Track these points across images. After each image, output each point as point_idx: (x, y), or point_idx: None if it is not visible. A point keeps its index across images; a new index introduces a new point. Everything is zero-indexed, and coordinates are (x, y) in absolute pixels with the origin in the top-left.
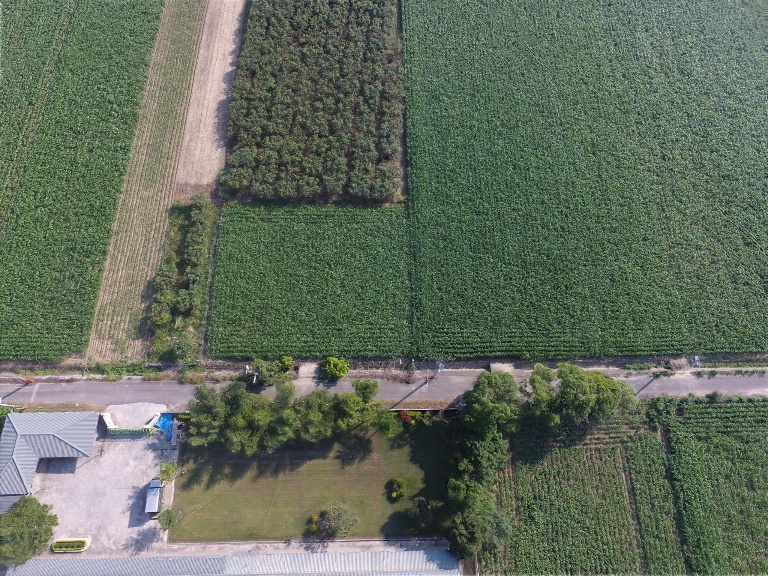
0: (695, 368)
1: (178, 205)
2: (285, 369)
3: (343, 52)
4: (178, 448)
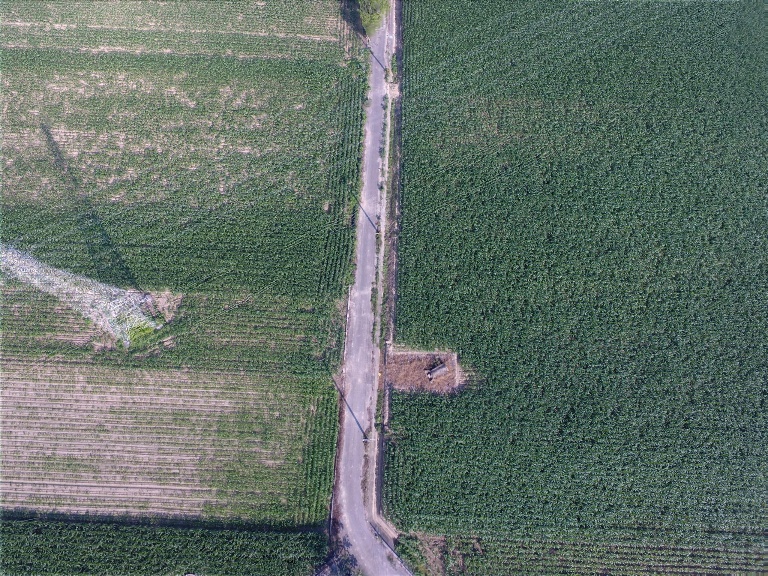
0: None
1: None
2: None
3: None
4: None
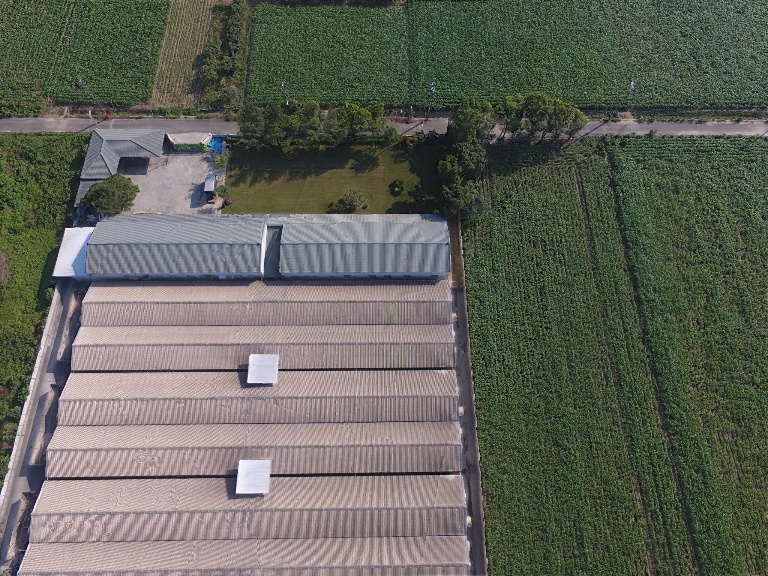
0: None
1: (219, 5)
2: None
3: None
4: None
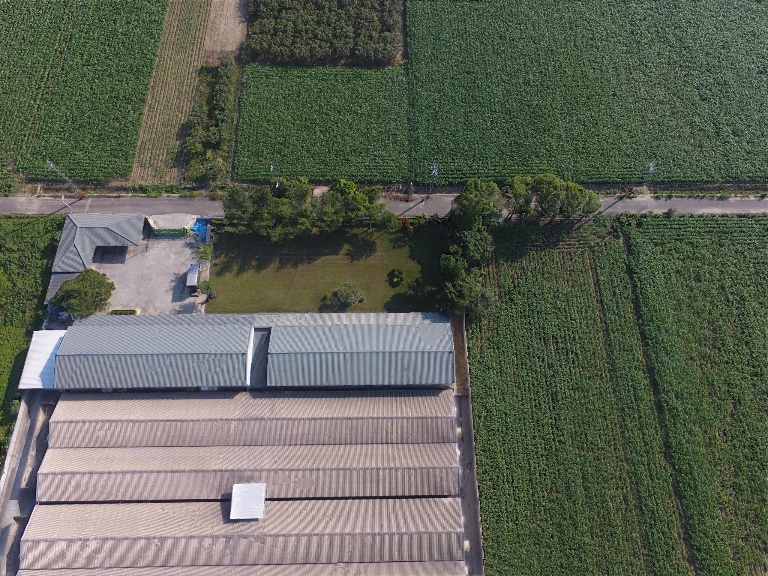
0: (654, 194)
1: (206, 66)
2: None
3: None
4: None
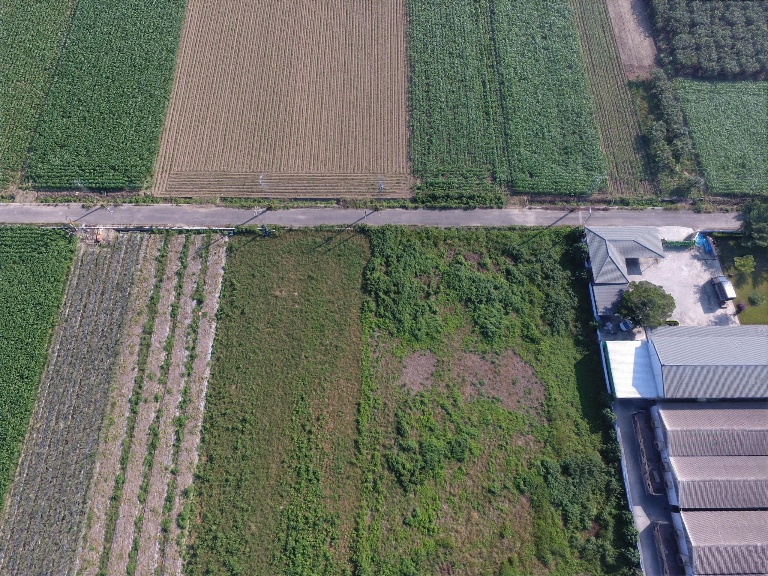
0: None
1: (633, 81)
2: None
3: None
4: (717, 259)
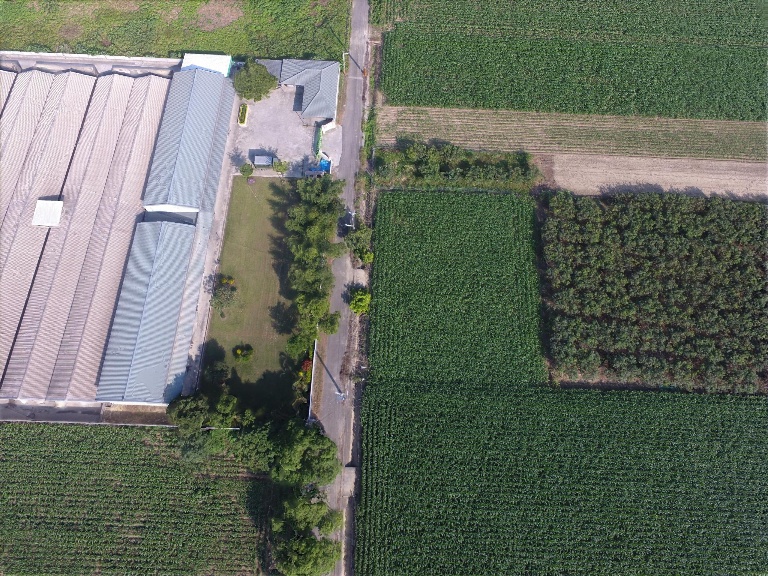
0: None
1: (528, 158)
2: (362, 256)
3: (761, 314)
4: (303, 177)
